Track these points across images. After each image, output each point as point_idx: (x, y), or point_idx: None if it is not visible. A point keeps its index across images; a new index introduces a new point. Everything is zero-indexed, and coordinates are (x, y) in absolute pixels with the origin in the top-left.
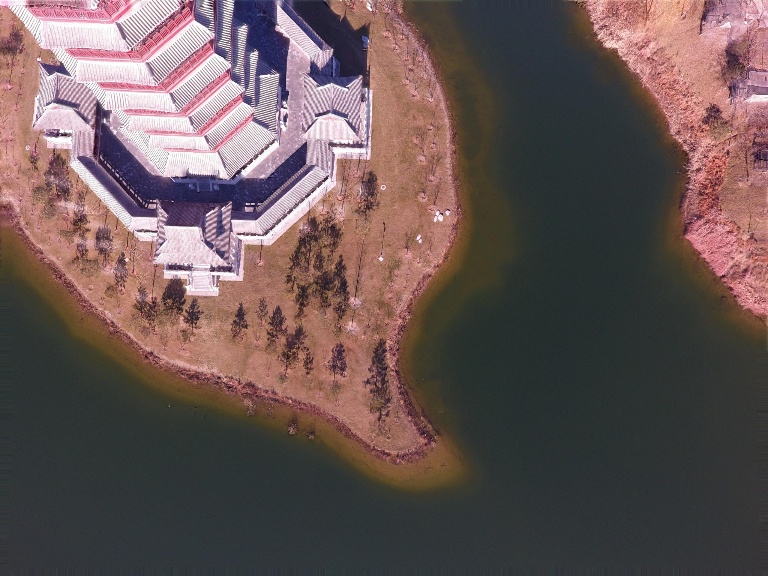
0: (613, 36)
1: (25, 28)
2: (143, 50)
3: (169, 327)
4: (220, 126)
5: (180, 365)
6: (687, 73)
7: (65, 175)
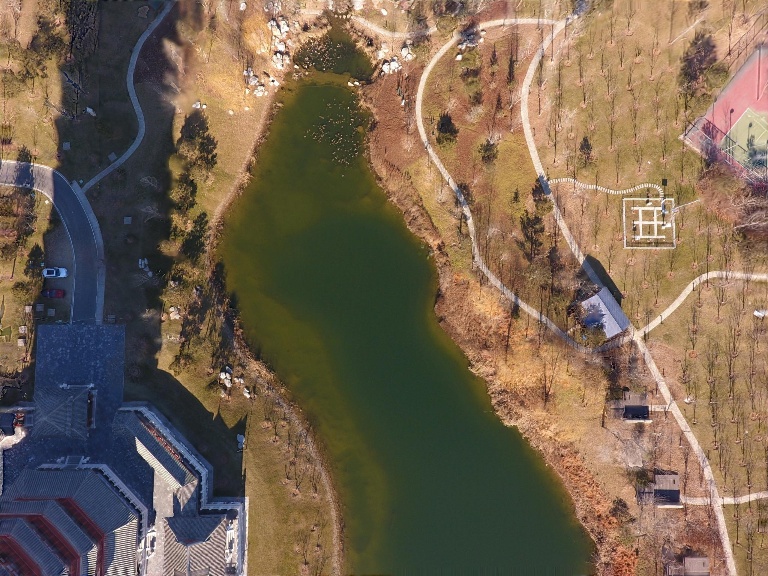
0: (511, 414)
1: None
2: None
3: None
4: None
5: None
6: (591, 462)
7: None
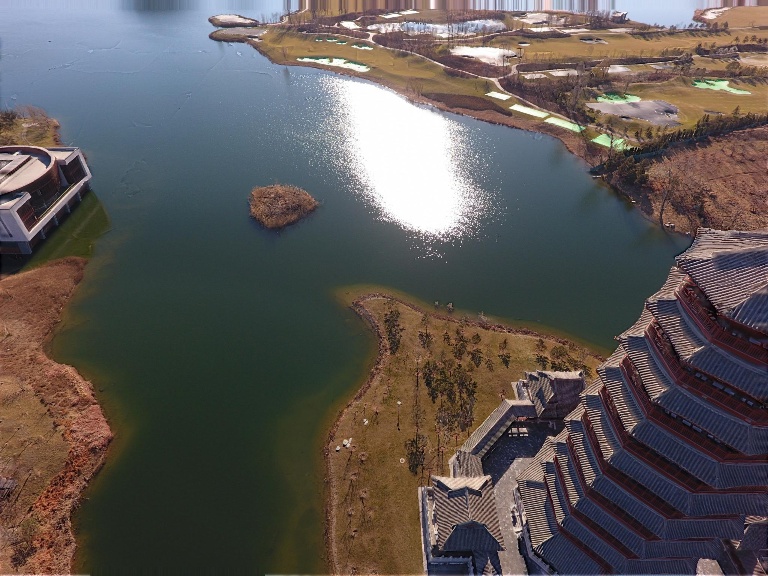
0: None
1: None
2: None
3: None
4: None
5: None
6: None
7: None
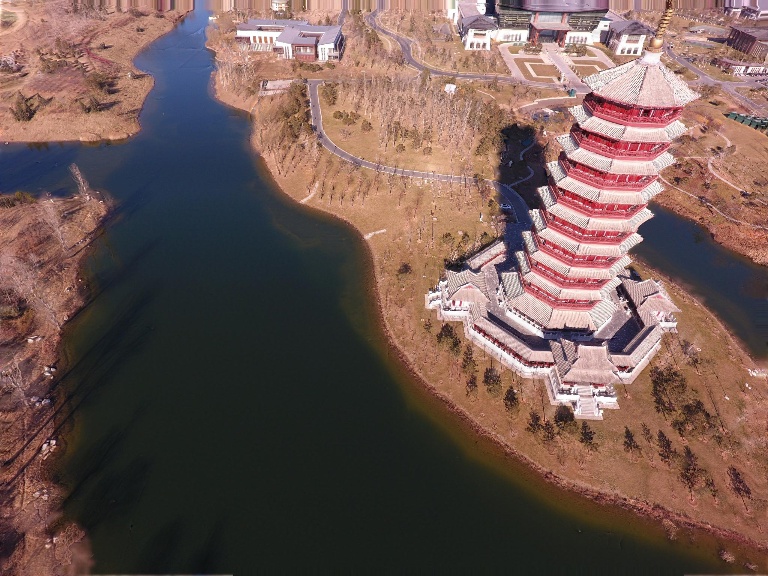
0: None
1: (412, 263)
2: (633, 212)
3: (565, 446)
4: (603, 288)
5: (581, 485)
6: None
7: (454, 335)
